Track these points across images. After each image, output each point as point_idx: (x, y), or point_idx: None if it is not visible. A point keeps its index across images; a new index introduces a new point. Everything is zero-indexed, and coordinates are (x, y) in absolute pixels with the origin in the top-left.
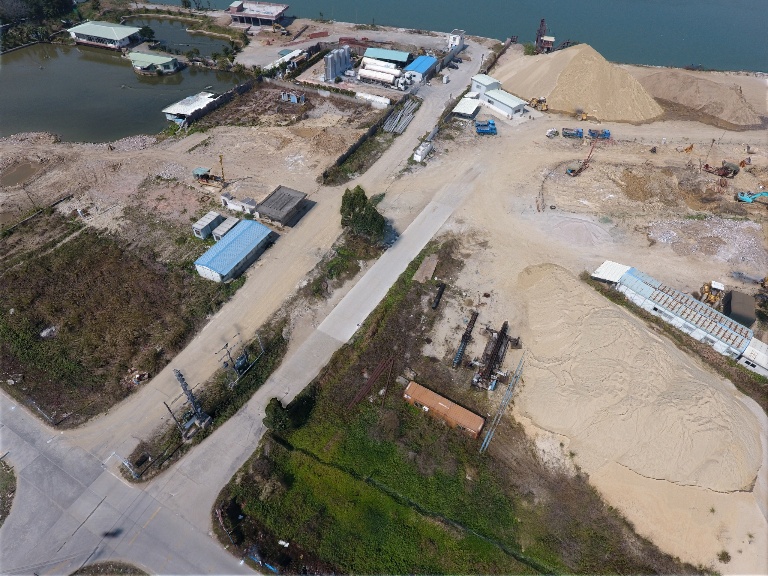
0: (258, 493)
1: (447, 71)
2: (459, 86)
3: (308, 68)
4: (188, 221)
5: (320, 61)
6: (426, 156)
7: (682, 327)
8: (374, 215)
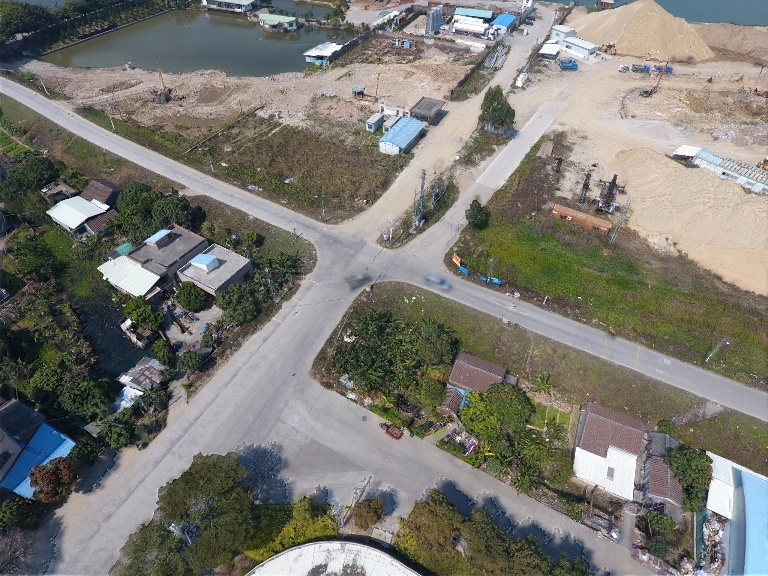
0: (470, 255)
1: (524, 27)
2: (537, 37)
3: (408, 24)
4: (357, 122)
5: (416, 19)
6: (524, 83)
7: (745, 184)
8: (508, 108)
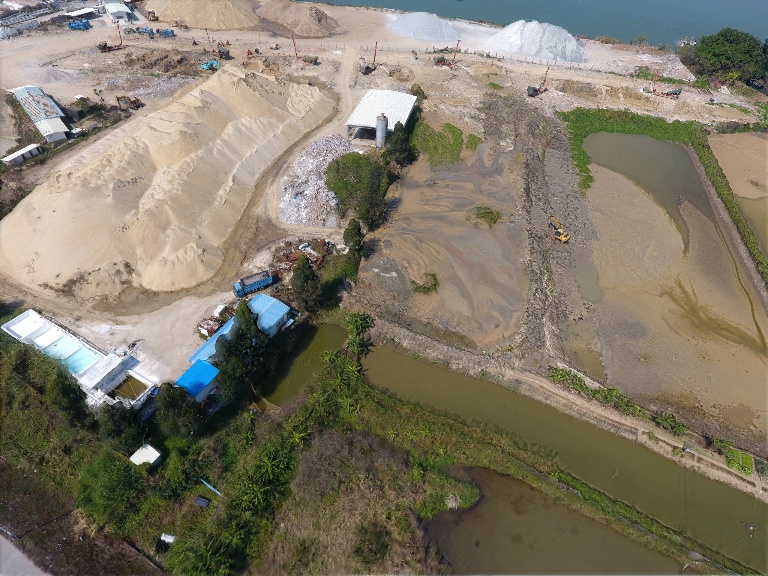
0: None
1: None
2: None
3: None
4: None
5: None
6: (6, 37)
7: None
8: None
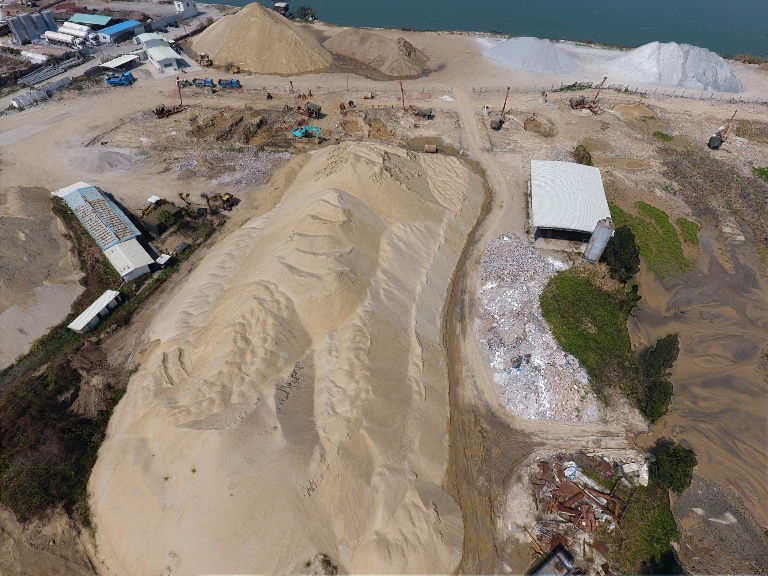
0: None
1: None
2: None
3: None
4: None
5: None
6: (33, 103)
7: None
8: None
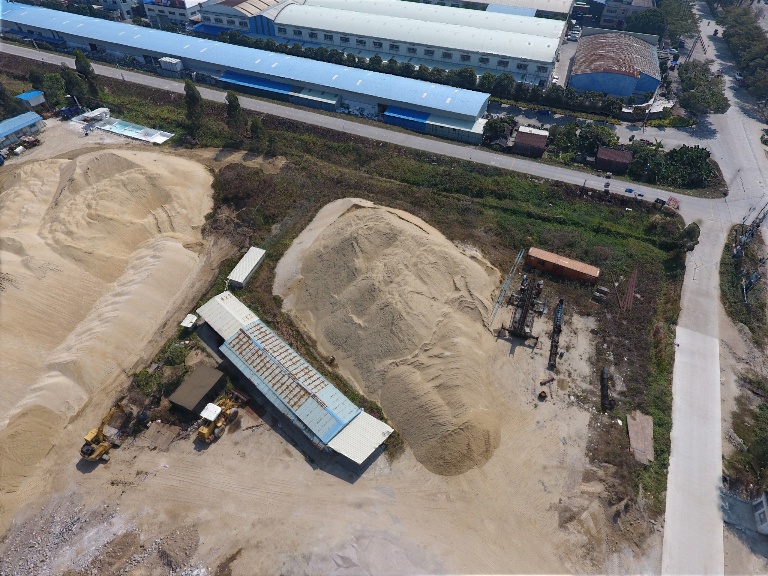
0: None
1: None
2: None
3: None
4: None
5: None
6: None
7: None
8: None
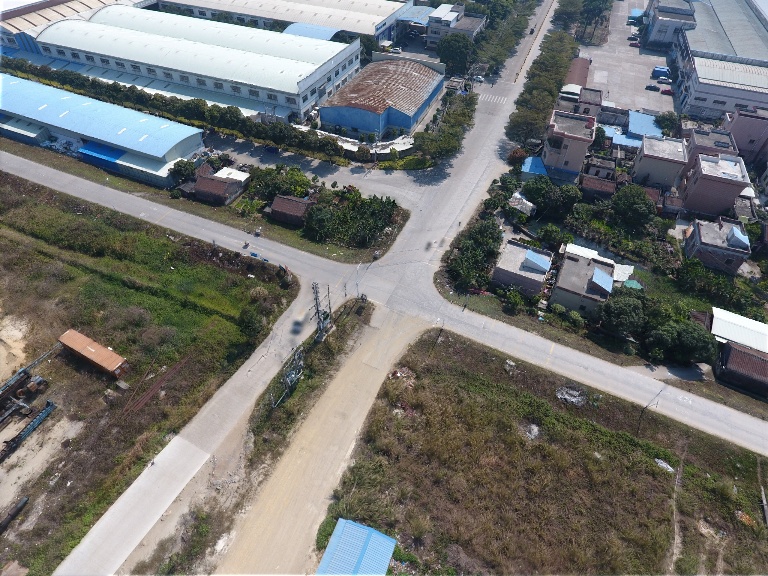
0: None
1: None
2: None
3: None
4: None
5: None
6: None
7: None
8: None
